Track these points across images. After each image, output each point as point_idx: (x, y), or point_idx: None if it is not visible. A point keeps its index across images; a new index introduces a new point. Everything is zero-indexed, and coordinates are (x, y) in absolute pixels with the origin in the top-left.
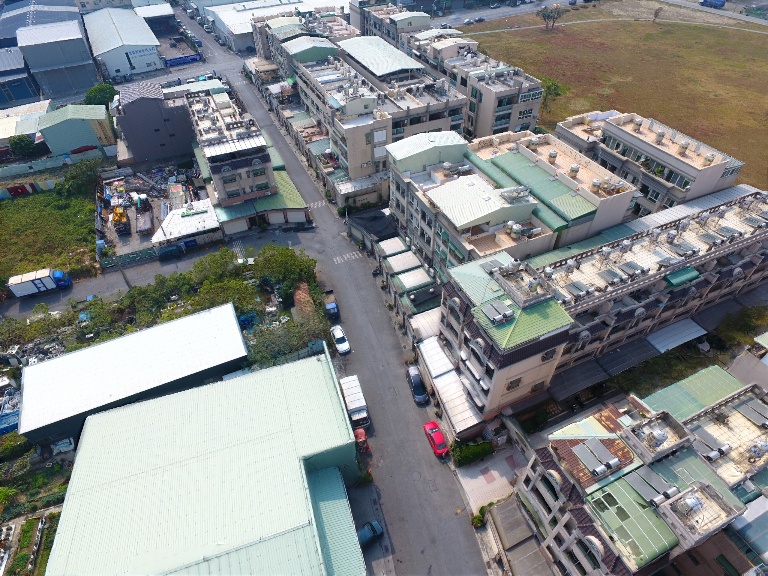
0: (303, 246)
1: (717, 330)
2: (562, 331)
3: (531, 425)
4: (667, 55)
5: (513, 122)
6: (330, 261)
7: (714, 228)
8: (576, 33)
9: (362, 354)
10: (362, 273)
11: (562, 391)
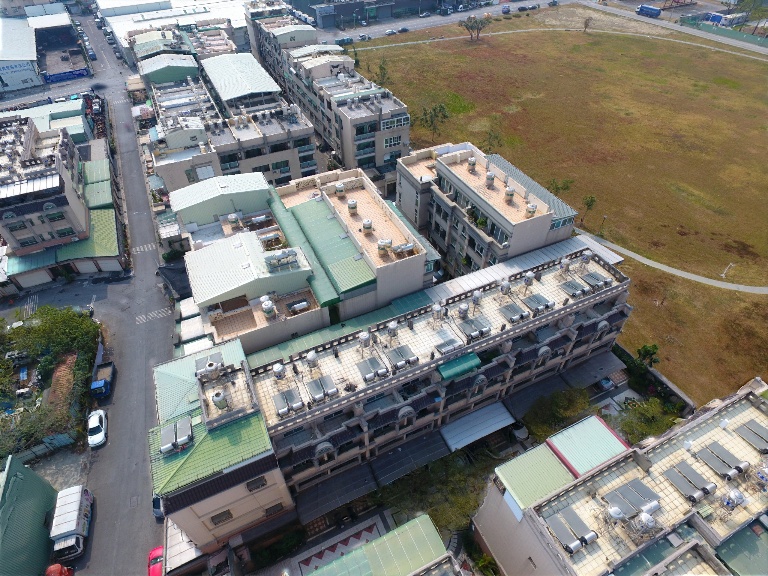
0: (107, 301)
1: (524, 420)
2: (263, 457)
3: (279, 550)
4: (588, 69)
5: (379, 151)
6: (131, 321)
7: (523, 296)
8: (501, 44)
9: (118, 448)
10: (162, 336)
11: (311, 511)
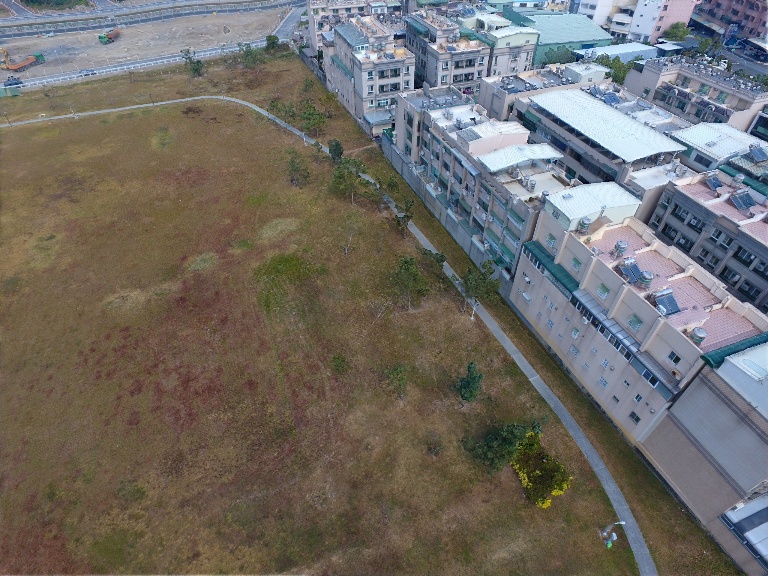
0: None
1: None
2: None
3: None
4: None
5: None
6: None
7: None
8: None
9: None
10: None
11: None
